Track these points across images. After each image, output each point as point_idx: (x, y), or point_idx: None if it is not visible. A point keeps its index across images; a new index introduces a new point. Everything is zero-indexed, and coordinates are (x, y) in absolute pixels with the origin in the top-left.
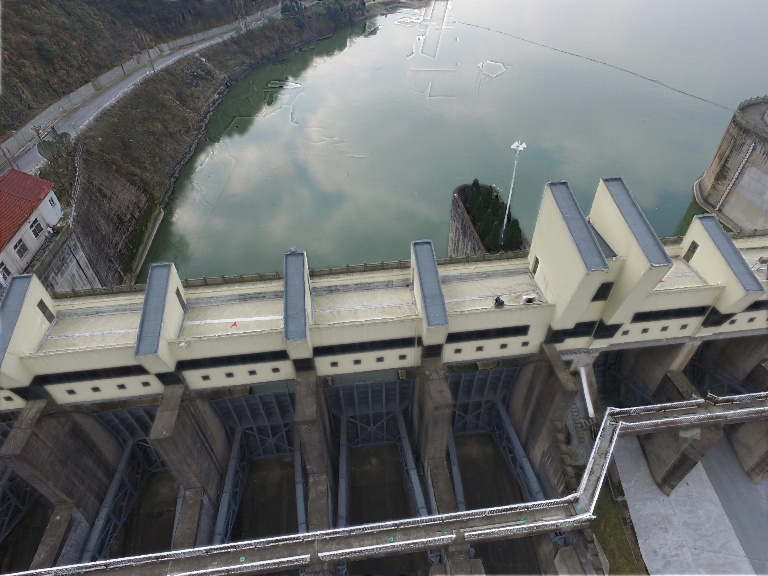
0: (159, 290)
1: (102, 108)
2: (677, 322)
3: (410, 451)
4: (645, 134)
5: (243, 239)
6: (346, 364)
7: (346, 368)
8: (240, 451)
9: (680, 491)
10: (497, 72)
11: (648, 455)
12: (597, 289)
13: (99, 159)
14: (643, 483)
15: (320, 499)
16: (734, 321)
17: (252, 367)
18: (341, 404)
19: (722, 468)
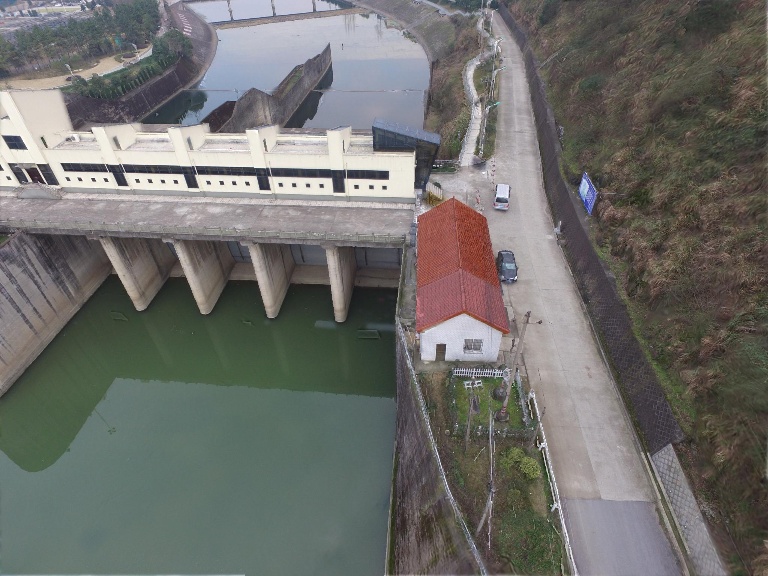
0: None
1: None
2: None
3: None
4: None
5: (209, 568)
6: None
7: None
8: None
9: None
10: None
11: None
12: None
13: None
14: None
15: None
16: None
17: None
18: None
19: None
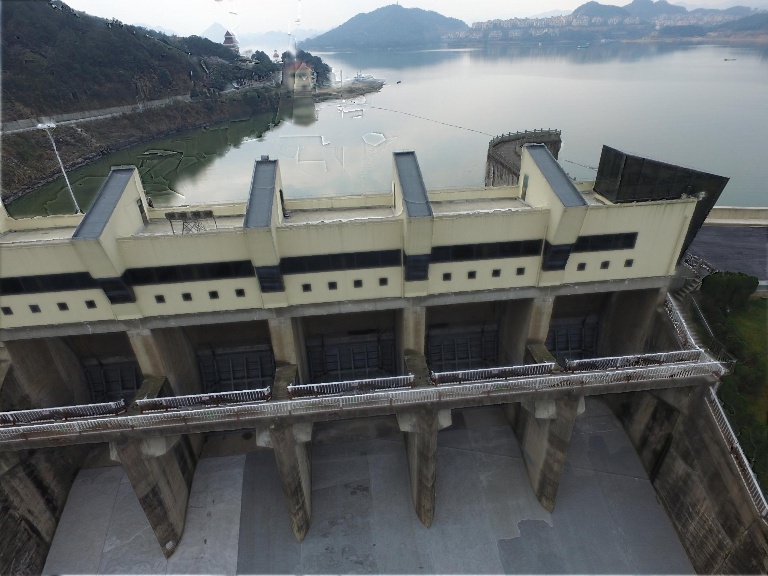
0: None
1: None
2: (73, 296)
3: None
4: (469, 182)
5: None
6: None
7: None
8: None
9: (189, 551)
10: (378, 142)
11: None
12: None
13: None
14: (145, 539)
15: None
16: (163, 298)
17: None
18: None
19: (265, 520)
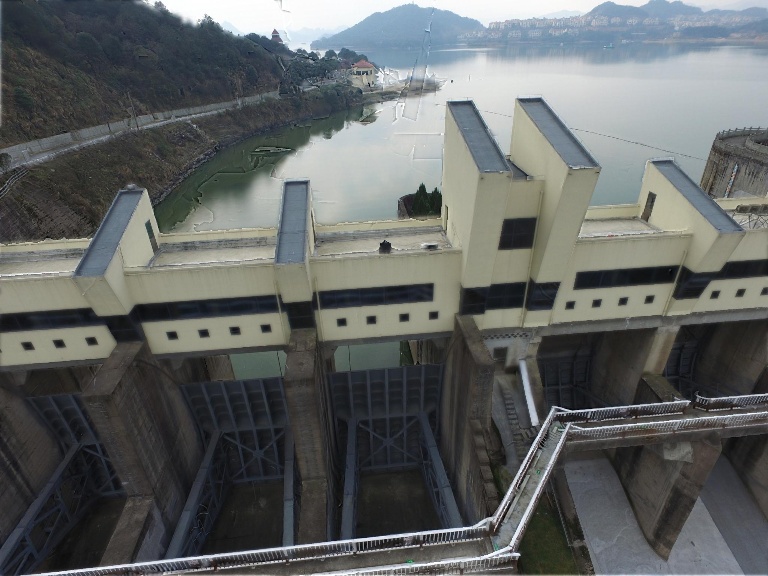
0: None
1: (68, 149)
2: (638, 291)
3: (292, 476)
4: (628, 181)
5: None
6: (189, 336)
7: (190, 343)
8: (69, 475)
9: (683, 554)
10: None
11: (634, 501)
12: (503, 211)
13: (43, 185)
14: (630, 541)
15: (130, 531)
16: (717, 294)
17: (57, 334)
18: (210, 412)
19: (740, 522)
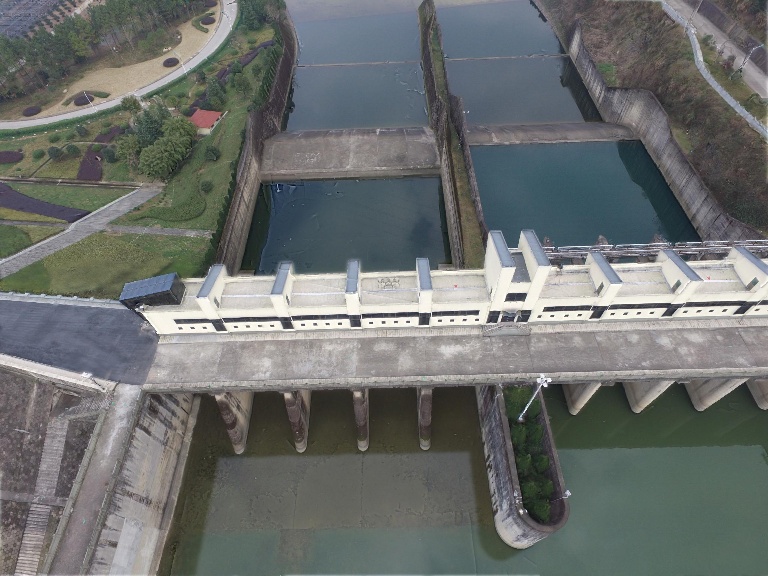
0: (764, 269)
1: None
2: None
3: None
4: None
5: None
6: None
7: None
8: None
9: None
10: None
11: None
12: None
13: None
14: None
15: None
16: None
17: None
18: None
19: None
